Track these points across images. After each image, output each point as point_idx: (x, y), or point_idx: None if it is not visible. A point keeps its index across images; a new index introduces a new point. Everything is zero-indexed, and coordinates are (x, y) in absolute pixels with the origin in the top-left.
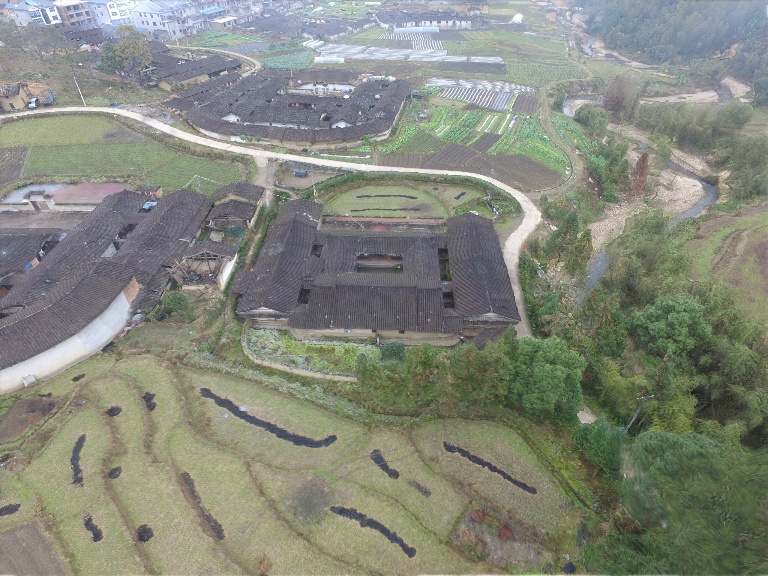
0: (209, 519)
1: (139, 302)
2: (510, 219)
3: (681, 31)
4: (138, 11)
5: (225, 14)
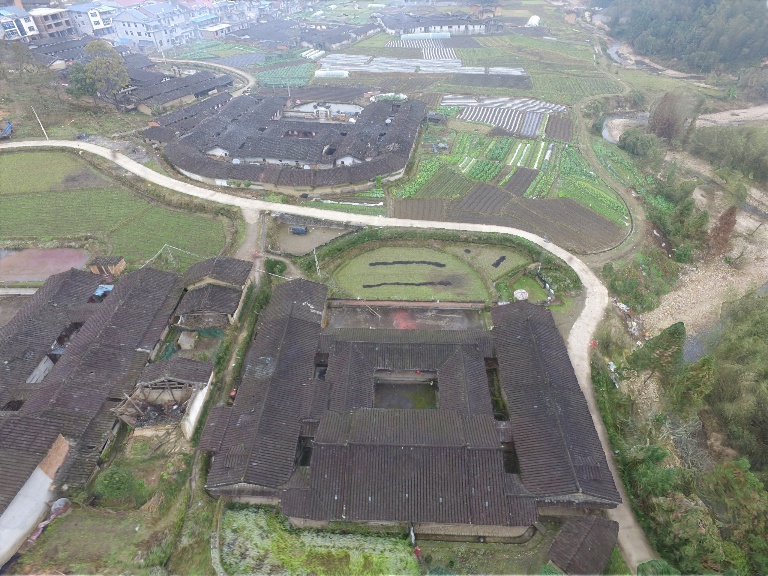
0: None
1: (67, 470)
2: (568, 299)
3: (724, 36)
4: (121, 20)
5: (217, 21)
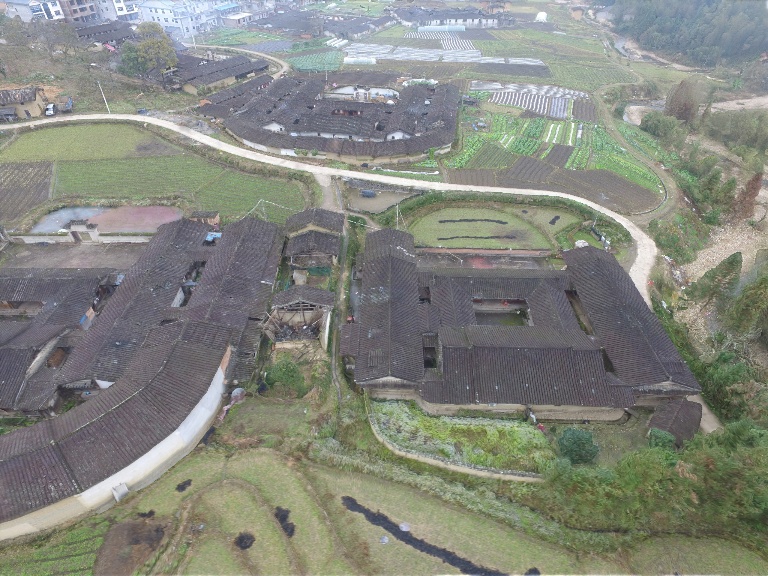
0: None
1: (233, 369)
2: (622, 249)
3: (727, 32)
4: (148, 6)
5: (238, 10)
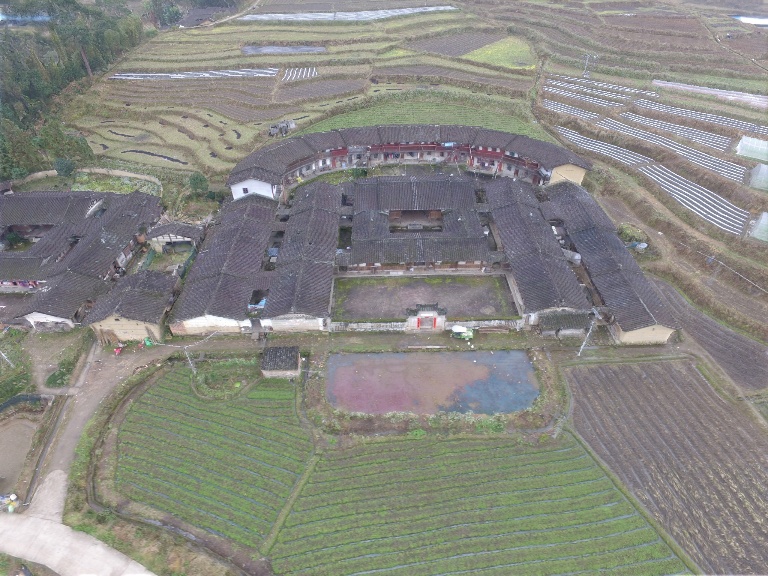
0: (183, 132)
1: None
2: None
3: None
4: None
5: None
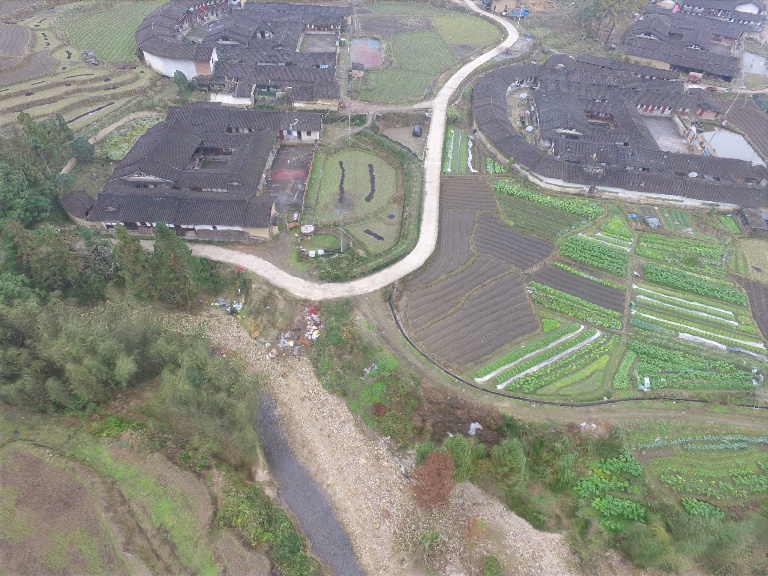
0: None
1: (202, 78)
2: (305, 267)
3: None
4: None
5: None
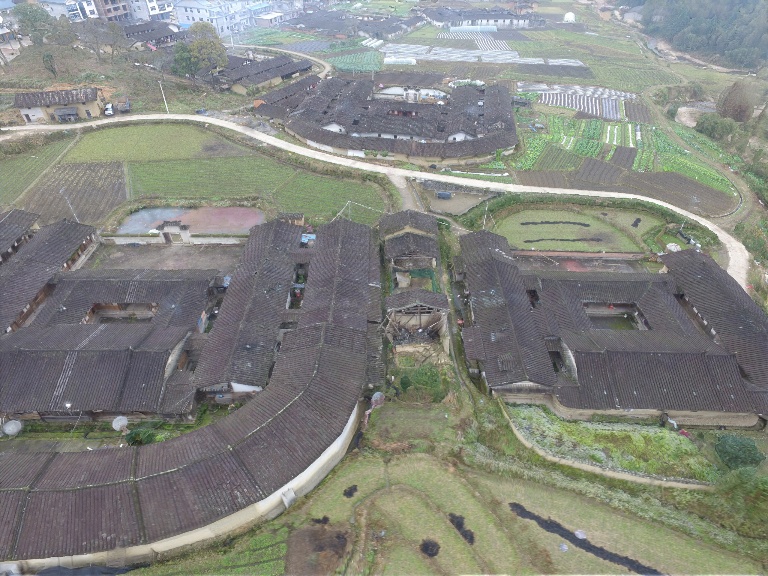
0: None
1: (365, 373)
2: (713, 252)
3: (766, 34)
4: (183, 6)
5: (269, 10)
